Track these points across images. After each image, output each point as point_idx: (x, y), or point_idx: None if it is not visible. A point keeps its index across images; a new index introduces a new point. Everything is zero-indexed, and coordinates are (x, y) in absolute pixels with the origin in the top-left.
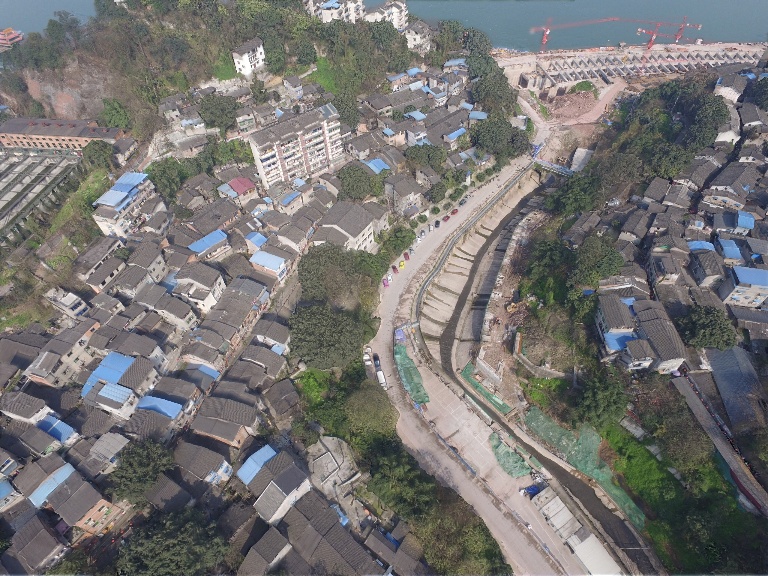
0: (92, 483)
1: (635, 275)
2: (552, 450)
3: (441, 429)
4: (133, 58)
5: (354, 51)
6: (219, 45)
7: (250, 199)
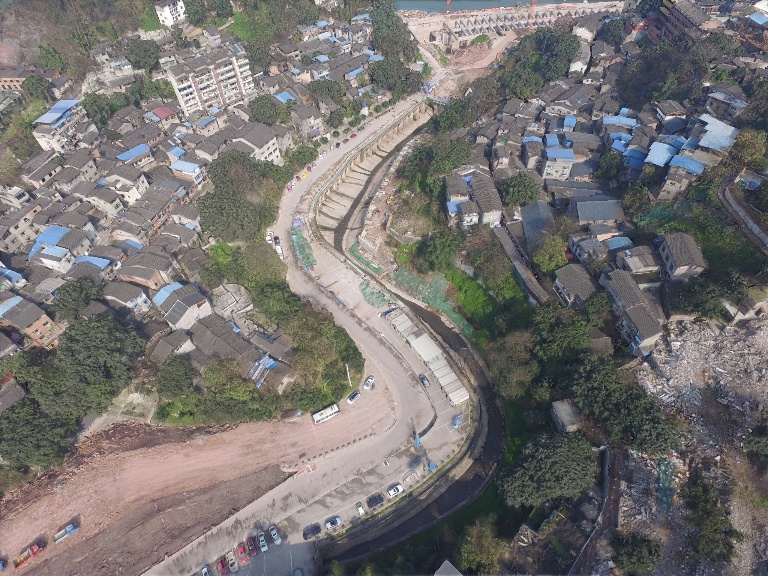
0: (38, 306)
1: (479, 163)
2: (412, 295)
3: (323, 281)
4: (65, 11)
5: (266, 6)
6: (143, 0)
7: (171, 123)
